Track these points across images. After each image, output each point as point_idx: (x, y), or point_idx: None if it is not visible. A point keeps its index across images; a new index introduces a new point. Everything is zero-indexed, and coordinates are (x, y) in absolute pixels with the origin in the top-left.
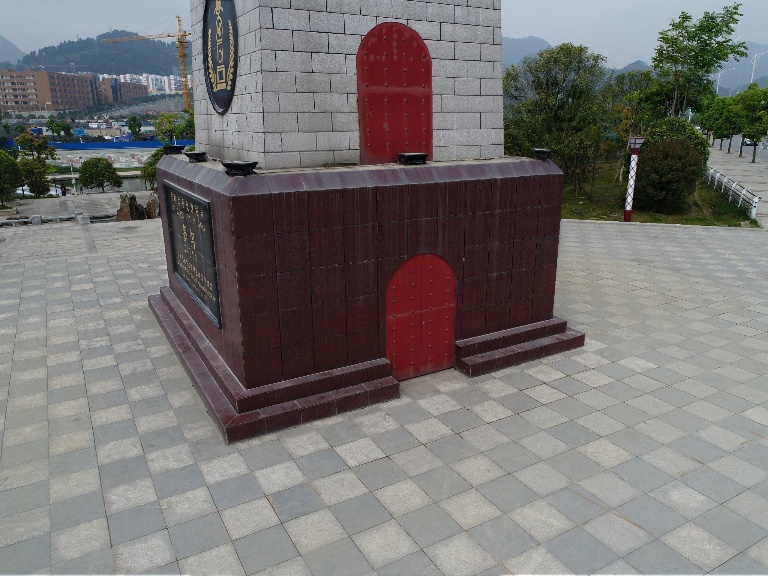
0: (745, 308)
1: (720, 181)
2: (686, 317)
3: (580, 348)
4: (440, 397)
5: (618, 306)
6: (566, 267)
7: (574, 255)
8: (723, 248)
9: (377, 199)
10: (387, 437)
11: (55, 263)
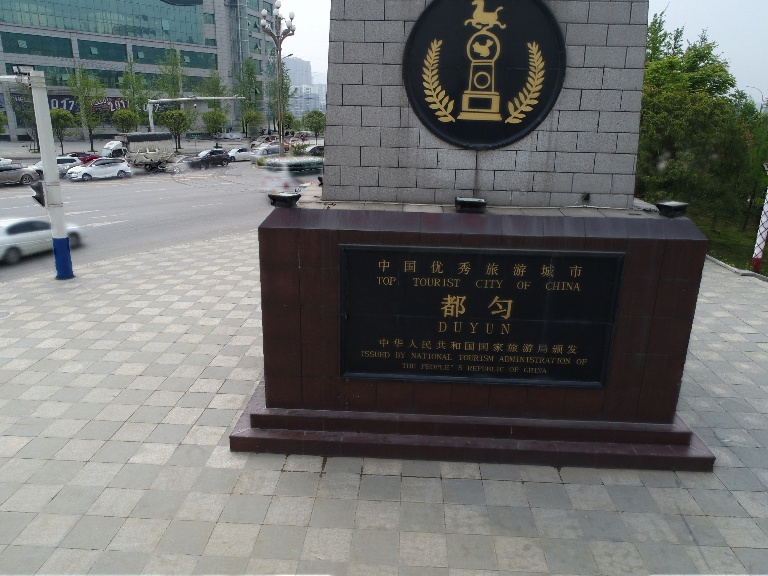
0: None
1: None
2: None
3: None
4: None
5: None
6: None
7: None
8: None
9: None
10: (255, 330)
11: (765, 295)
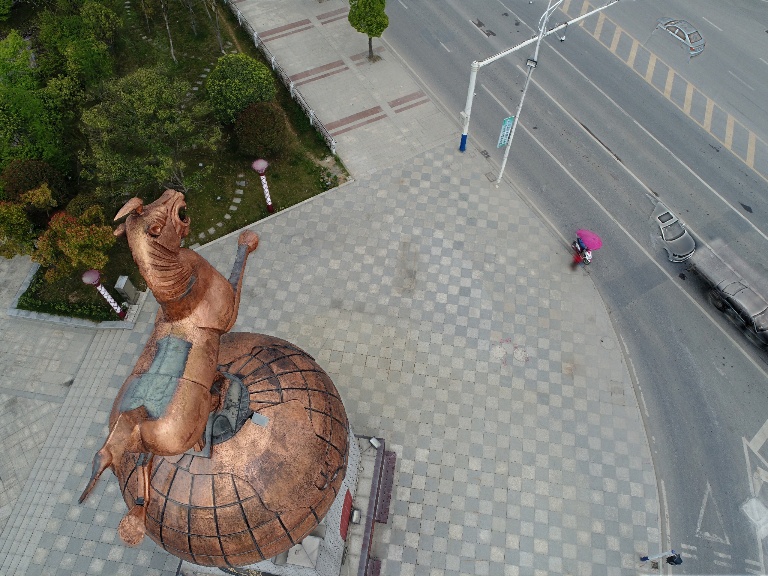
0: (417, 351)
1: (264, 52)
2: (406, 384)
3: (397, 458)
4: (391, 548)
5: (375, 393)
6: (313, 348)
7: (300, 321)
8: (356, 243)
9: (367, 553)
10: None
11: None
